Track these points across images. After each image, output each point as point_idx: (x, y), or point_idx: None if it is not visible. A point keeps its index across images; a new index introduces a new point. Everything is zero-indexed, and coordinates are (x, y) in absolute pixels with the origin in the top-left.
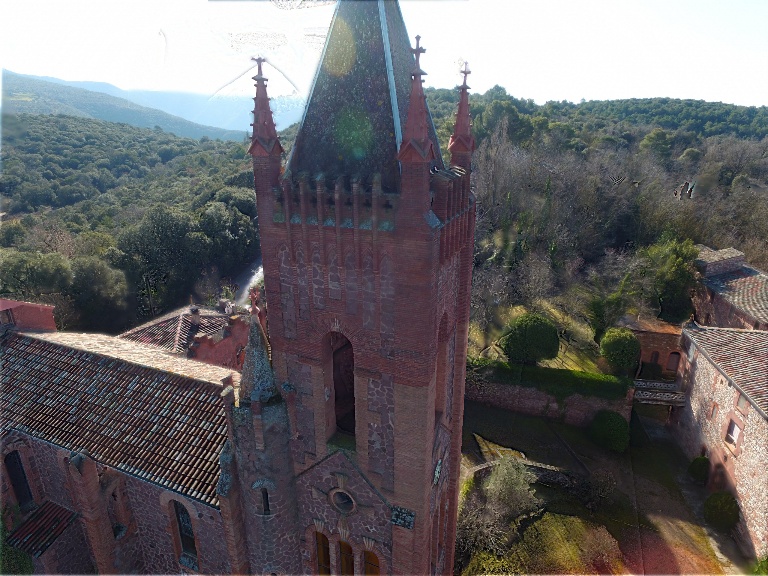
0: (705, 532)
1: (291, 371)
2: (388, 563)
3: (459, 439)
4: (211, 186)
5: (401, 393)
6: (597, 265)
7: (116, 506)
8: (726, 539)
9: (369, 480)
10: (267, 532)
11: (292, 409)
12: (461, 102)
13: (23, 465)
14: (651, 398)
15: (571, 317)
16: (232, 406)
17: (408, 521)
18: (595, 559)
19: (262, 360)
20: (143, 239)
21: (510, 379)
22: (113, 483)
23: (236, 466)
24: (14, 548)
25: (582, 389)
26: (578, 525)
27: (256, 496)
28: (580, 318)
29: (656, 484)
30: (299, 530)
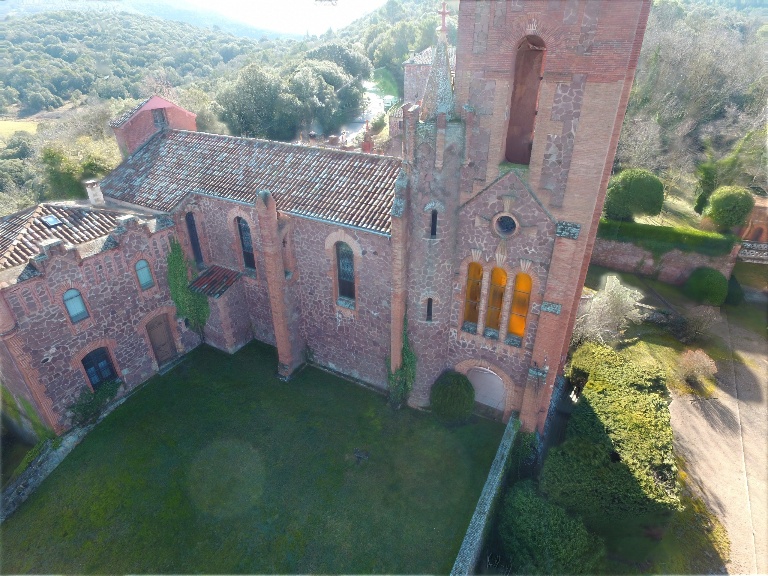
0: None
1: (473, 91)
2: (541, 283)
3: (602, 203)
4: (290, 63)
5: (591, 93)
6: (715, 123)
7: (284, 253)
8: None
9: (537, 198)
10: (431, 256)
11: (469, 132)
12: None
13: (196, 229)
14: (757, 257)
15: (680, 173)
16: (417, 123)
17: (573, 232)
18: (690, 374)
19: (446, 81)
20: (239, 98)
21: (606, 234)
22: (286, 227)
23: (409, 192)
24: (193, 296)
25: (683, 245)
26: (671, 353)
27: (426, 219)
28: (690, 174)
29: (752, 332)
30: (455, 263)
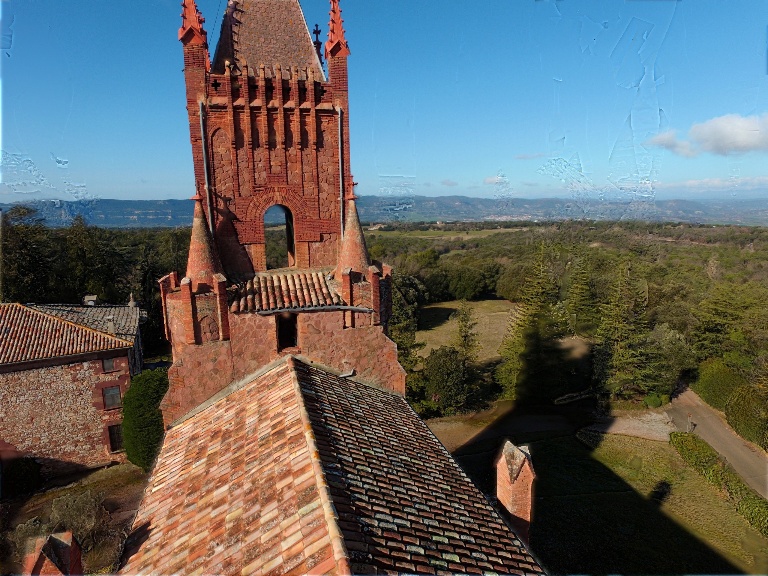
0: (40, 494)
1: None
2: None
3: None
4: None
5: None
6: None
7: None
8: (50, 483)
9: None
10: None
11: None
12: None
13: None
14: None
15: None
16: None
17: None
18: None
19: None
20: None
21: None
22: None
23: None
24: None
25: None
26: None
27: None
28: None
29: None
30: None
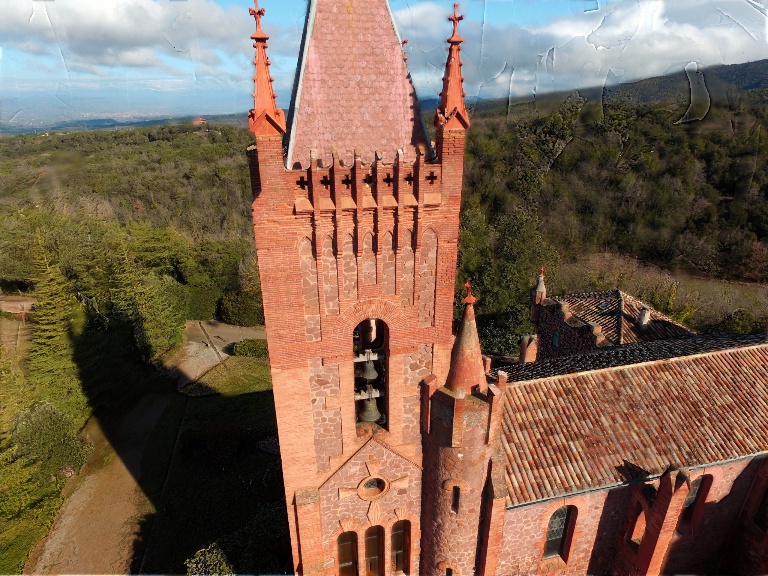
0: None
1: None
2: None
3: None
4: None
5: None
6: None
7: None
8: None
9: None
10: None
11: None
12: (265, 60)
13: None
14: None
15: None
16: None
17: None
18: None
19: None
20: None
21: None
22: None
23: None
24: None
25: None
26: None
27: None
28: None
29: None
30: None
